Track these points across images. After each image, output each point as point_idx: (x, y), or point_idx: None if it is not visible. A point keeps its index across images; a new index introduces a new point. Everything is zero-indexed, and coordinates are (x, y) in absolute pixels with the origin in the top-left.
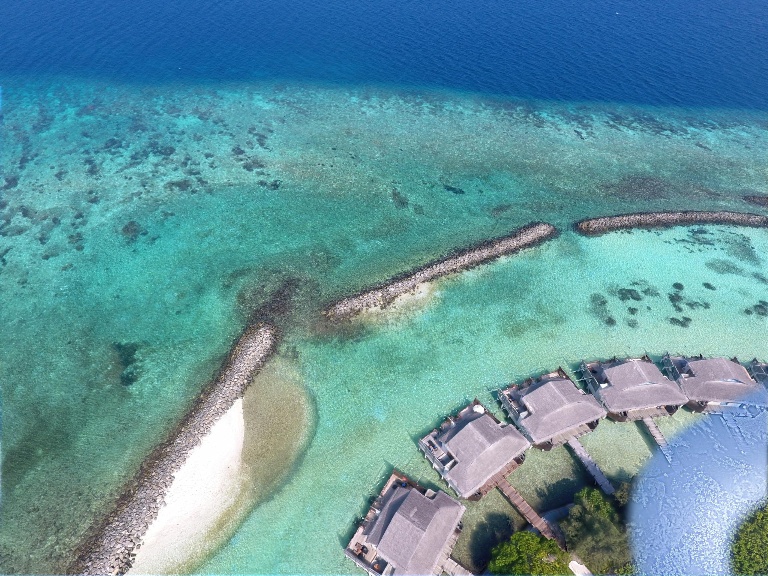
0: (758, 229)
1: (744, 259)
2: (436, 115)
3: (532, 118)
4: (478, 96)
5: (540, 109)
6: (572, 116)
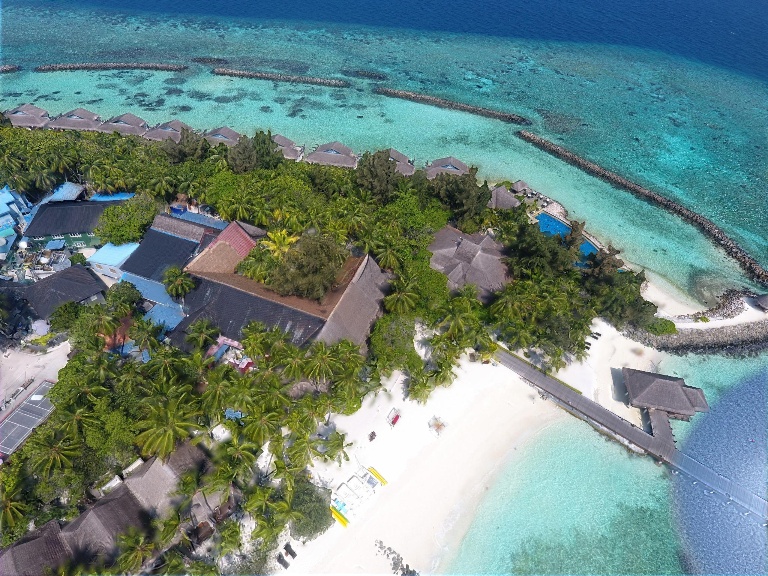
0: (170, 72)
1: (130, 83)
2: (42, 17)
3: (118, 20)
4: (98, 8)
5: (135, 16)
6: (153, 20)
